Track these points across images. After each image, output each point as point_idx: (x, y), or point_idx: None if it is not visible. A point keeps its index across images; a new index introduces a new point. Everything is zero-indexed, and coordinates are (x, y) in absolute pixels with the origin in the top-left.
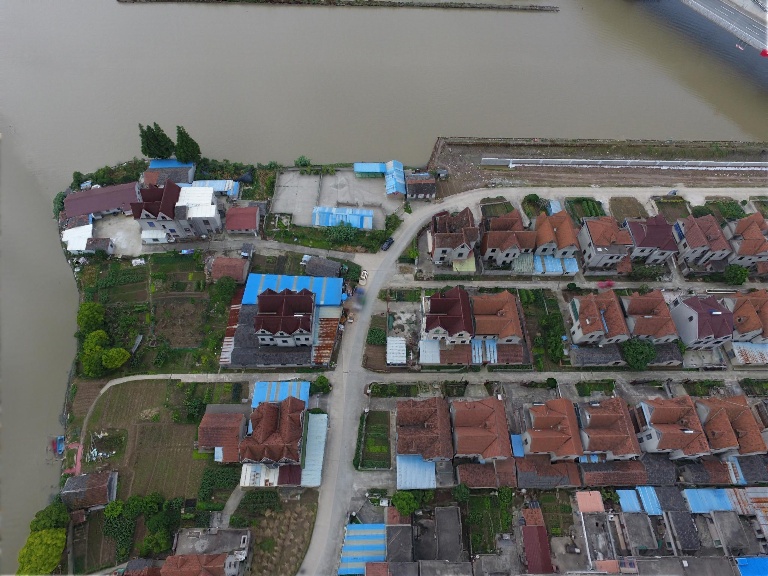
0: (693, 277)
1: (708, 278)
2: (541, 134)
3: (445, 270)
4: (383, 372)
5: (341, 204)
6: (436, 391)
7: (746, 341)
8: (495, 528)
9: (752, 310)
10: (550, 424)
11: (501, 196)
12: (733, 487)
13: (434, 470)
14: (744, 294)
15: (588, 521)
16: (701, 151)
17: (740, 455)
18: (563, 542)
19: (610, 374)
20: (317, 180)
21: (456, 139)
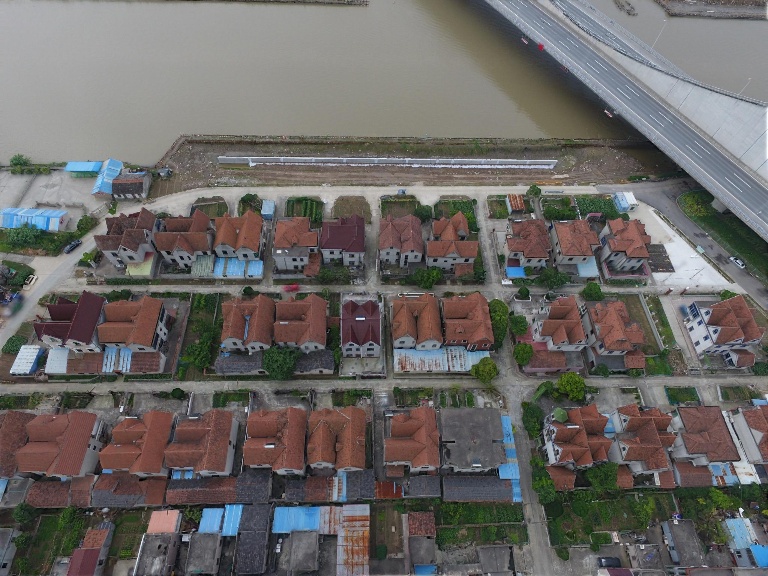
0: (390, 280)
1: (403, 281)
2: (294, 131)
3: (116, 274)
4: (7, 383)
5: (43, 205)
6: (56, 403)
7: (410, 348)
8: (58, 551)
9: (404, 315)
10: (132, 439)
11: (217, 196)
12: (331, 504)
13: (4, 489)
14: (439, 298)
15: (151, 543)
16: (459, 148)
17: (347, 470)
18: (129, 565)
19: (257, 383)
20: (29, 180)
21: (198, 137)
